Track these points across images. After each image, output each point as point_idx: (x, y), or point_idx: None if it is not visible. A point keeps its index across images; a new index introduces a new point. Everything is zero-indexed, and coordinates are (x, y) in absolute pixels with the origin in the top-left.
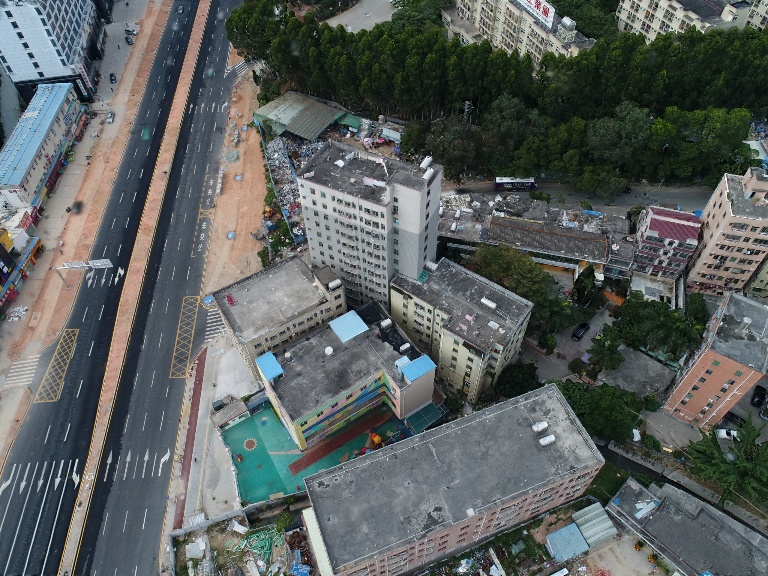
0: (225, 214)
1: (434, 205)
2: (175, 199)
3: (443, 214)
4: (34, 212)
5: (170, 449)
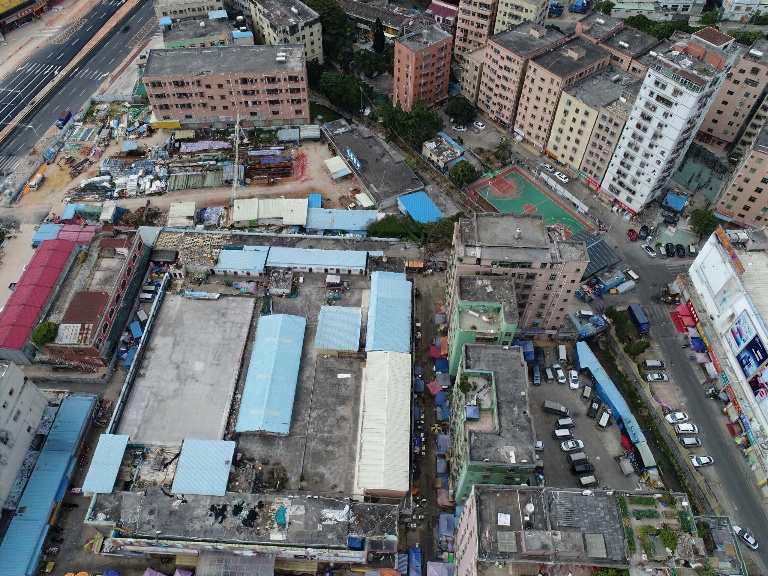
0: None
1: None
2: None
3: None
4: None
5: (110, 72)
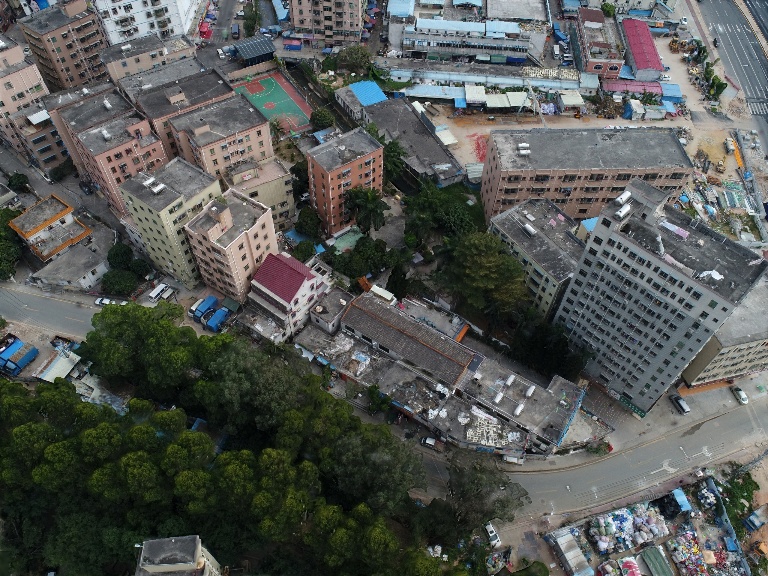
0: None
1: None
2: None
3: None
4: None
5: None
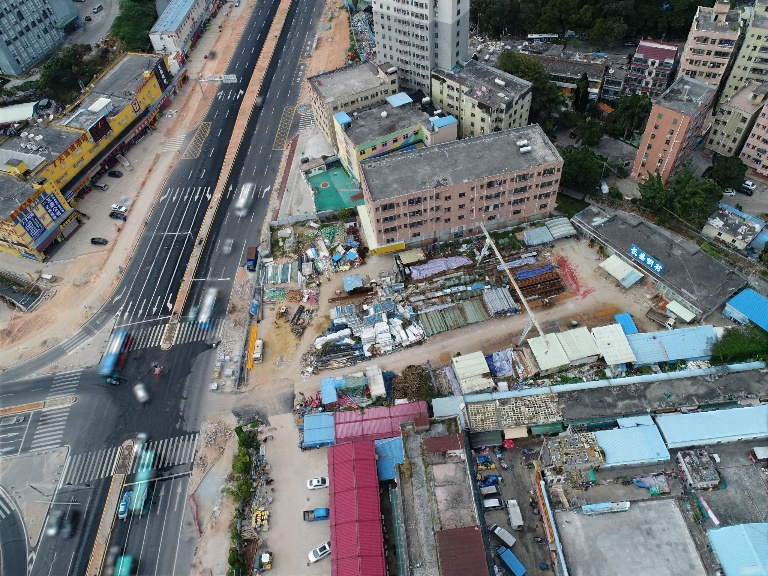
0: (318, 61)
1: (464, 7)
2: (282, 52)
3: (481, 51)
4: (183, 54)
5: (271, 185)
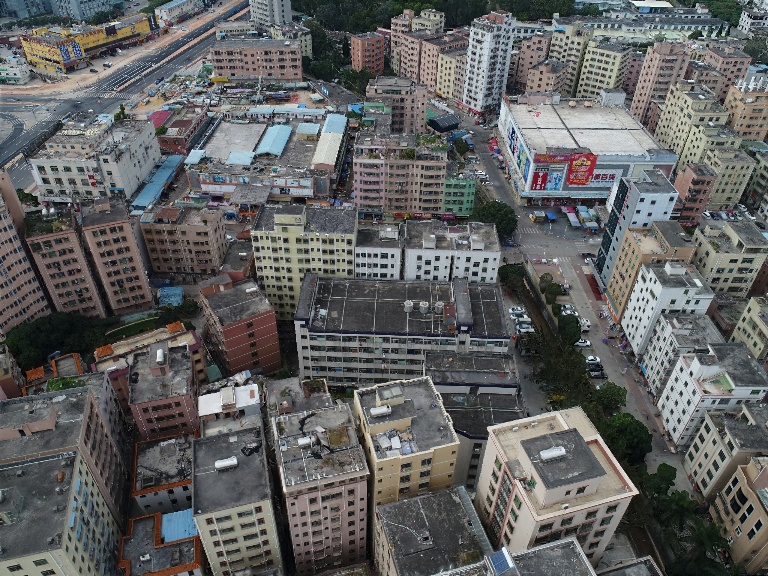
0: None
1: None
2: None
3: None
4: (170, 22)
5: (185, 65)
